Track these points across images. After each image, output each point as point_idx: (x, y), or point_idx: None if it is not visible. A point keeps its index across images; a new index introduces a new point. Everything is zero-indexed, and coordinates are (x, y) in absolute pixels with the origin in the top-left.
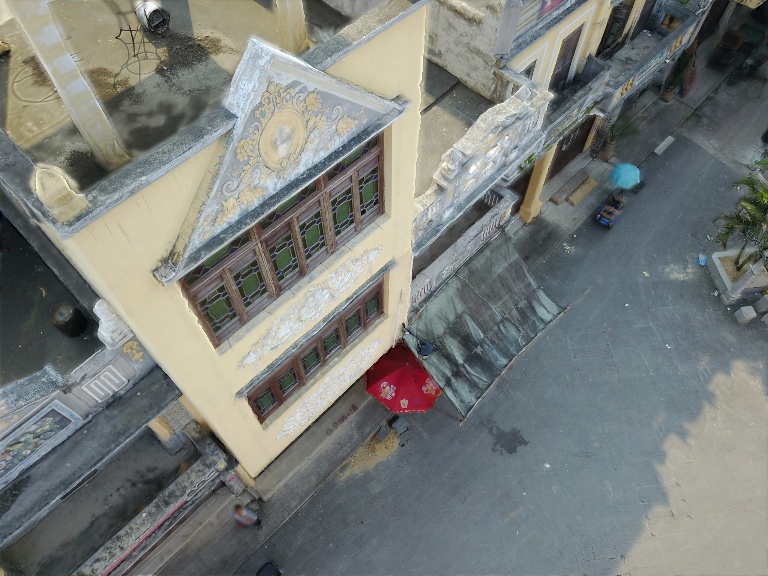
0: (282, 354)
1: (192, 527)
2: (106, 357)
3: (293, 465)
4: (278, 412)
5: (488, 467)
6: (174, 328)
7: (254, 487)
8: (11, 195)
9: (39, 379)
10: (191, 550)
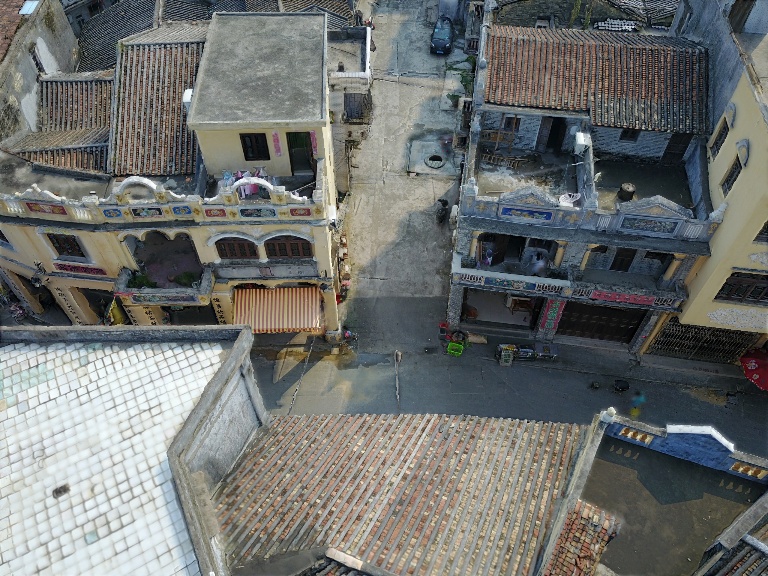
0: (760, 270)
1: (601, 345)
2: (704, 223)
3: (666, 364)
4: (722, 301)
5: (765, 455)
6: (761, 217)
7: (641, 356)
8: (707, 159)
9: (687, 210)
10: (594, 352)
